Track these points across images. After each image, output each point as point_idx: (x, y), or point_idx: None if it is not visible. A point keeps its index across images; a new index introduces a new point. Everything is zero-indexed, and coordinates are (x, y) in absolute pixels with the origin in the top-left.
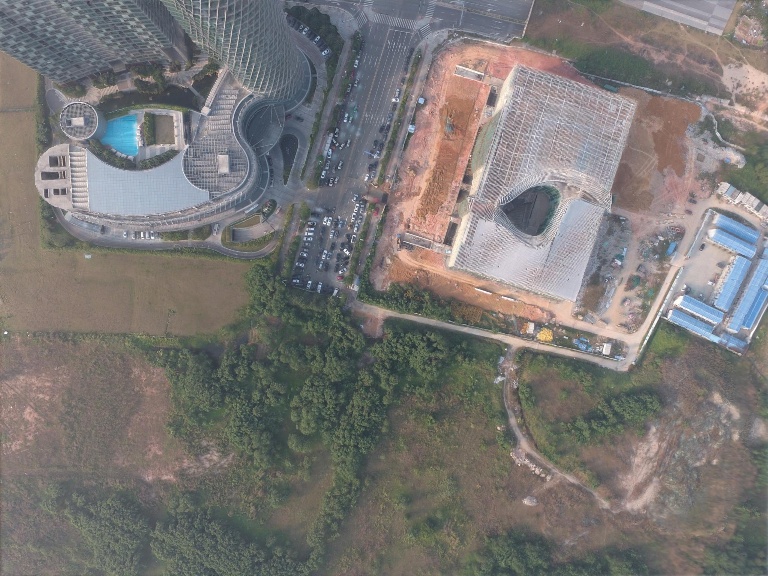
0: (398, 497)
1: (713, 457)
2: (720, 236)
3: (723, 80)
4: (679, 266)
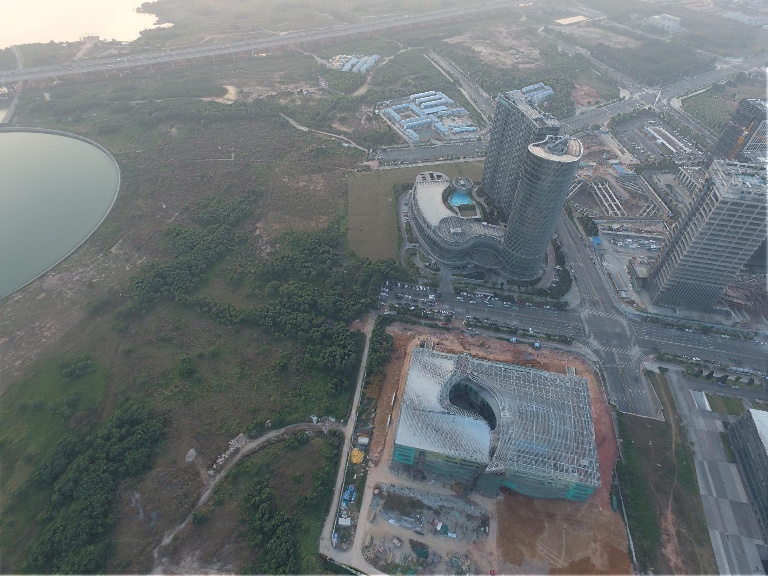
0: None
1: None
2: None
3: None
4: None
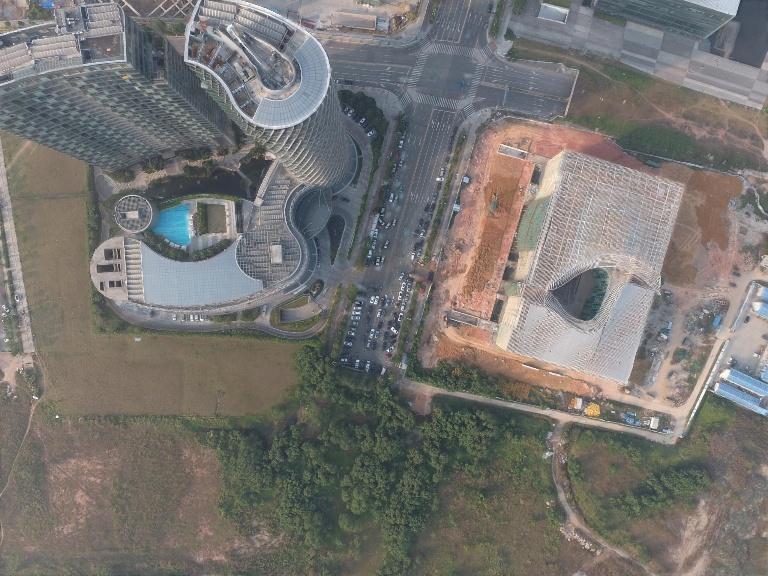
0: (449, 575)
1: (763, 530)
2: (765, 310)
3: (764, 154)
4: (724, 339)
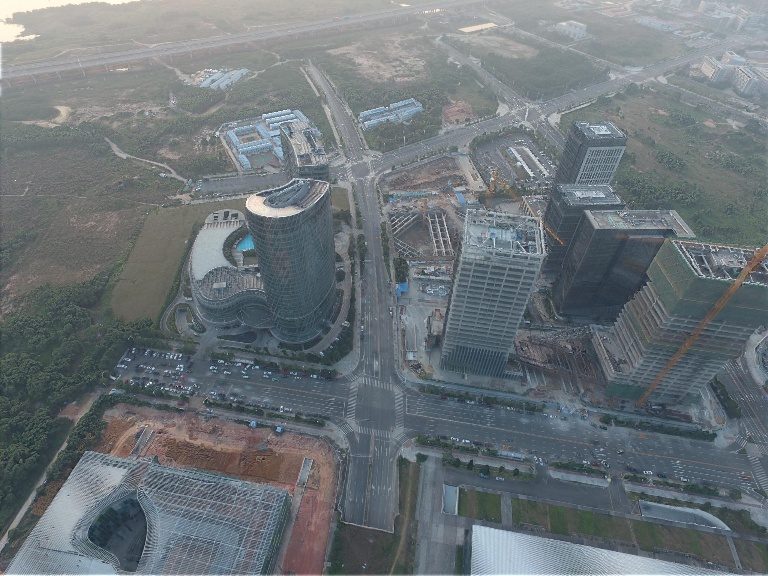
0: None
1: None
2: None
3: None
4: None
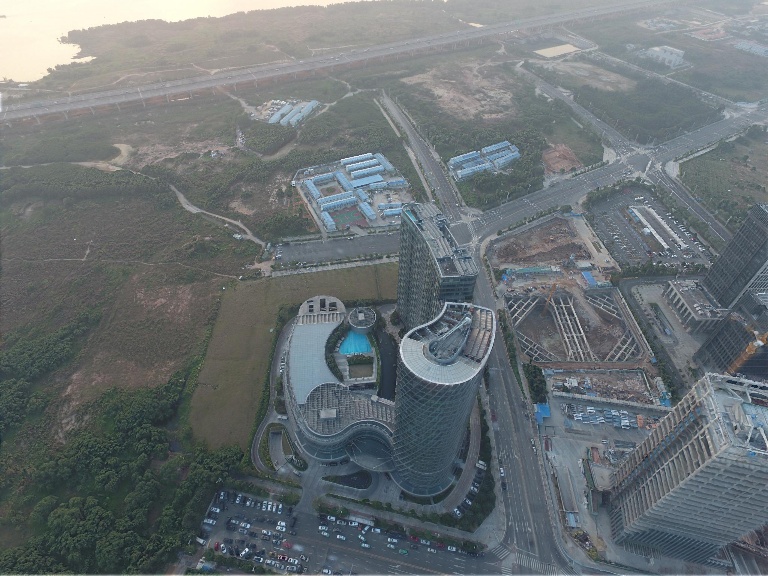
0: None
1: None
2: None
3: None
4: None
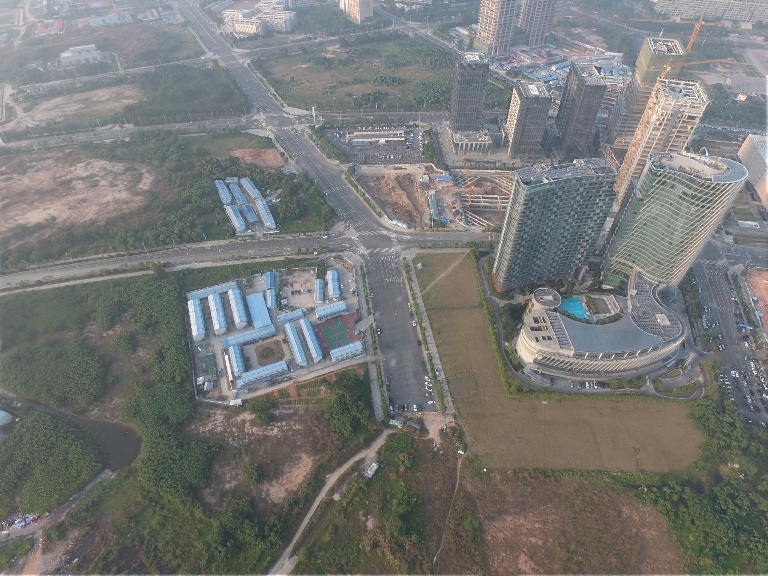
0: None
1: None
2: None
3: None
4: None
